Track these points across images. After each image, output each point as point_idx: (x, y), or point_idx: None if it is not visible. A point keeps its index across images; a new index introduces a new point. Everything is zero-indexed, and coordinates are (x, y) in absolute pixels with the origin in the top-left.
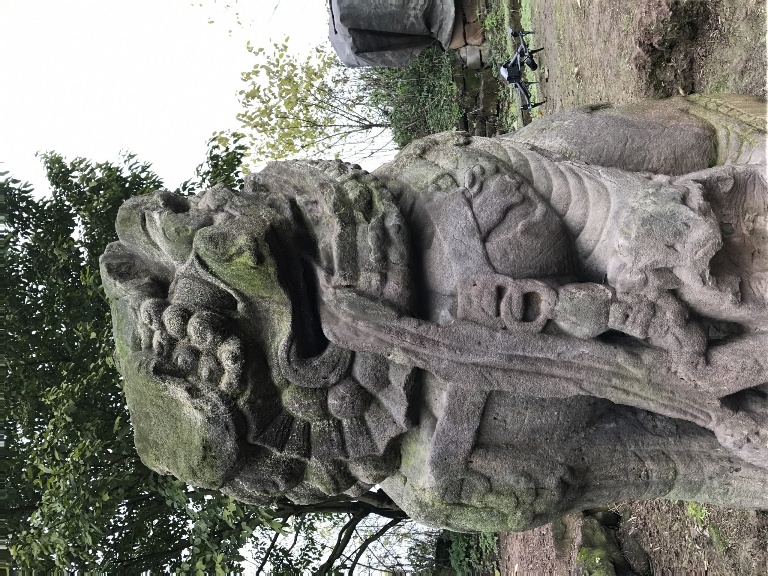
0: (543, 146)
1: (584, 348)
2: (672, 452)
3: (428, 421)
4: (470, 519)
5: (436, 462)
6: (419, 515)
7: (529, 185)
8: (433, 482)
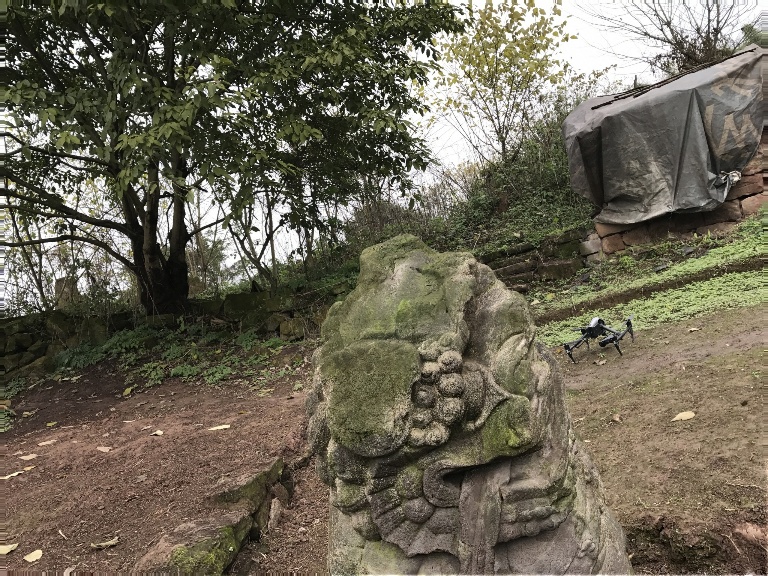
0: None
1: None
2: None
3: (416, 566)
4: None
5: None
6: (342, 567)
7: None
8: None
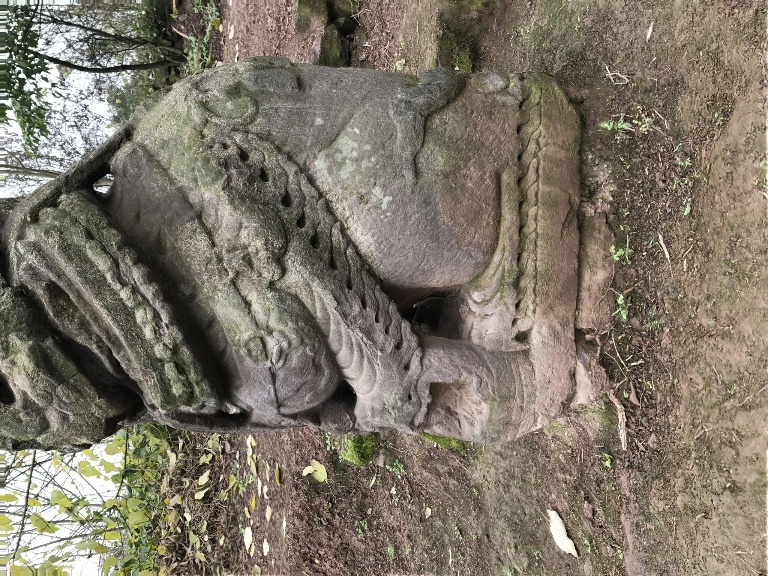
0: (354, 235)
1: None
2: None
3: None
4: None
5: None
6: None
7: (324, 346)
8: None
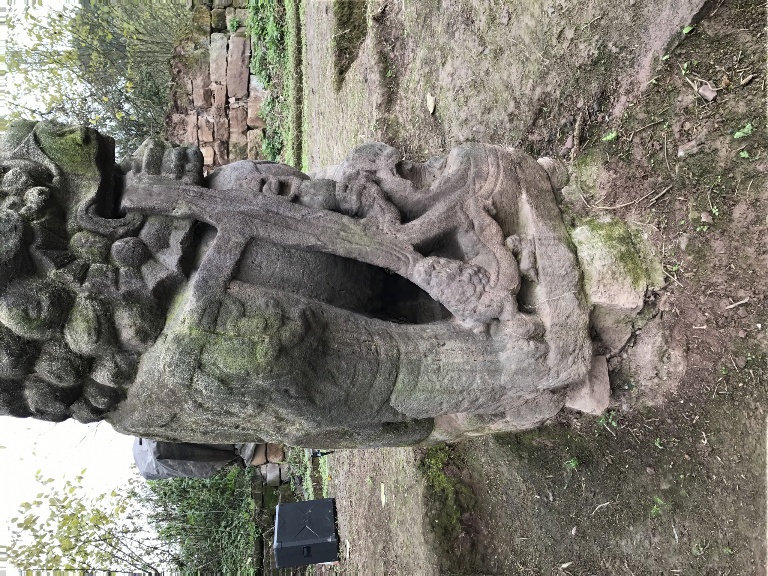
0: None
1: (320, 213)
2: (394, 333)
3: None
4: (223, 349)
5: (199, 285)
6: (174, 354)
7: None
8: (194, 305)
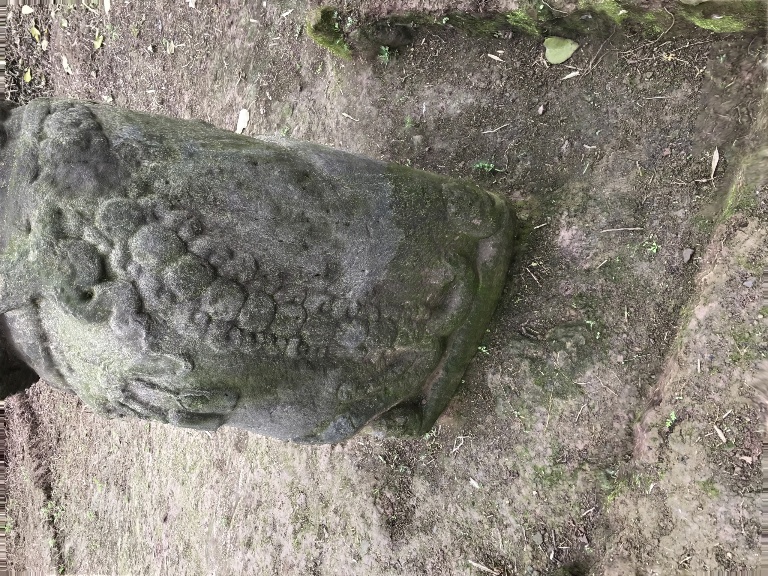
0: None
1: None
2: None
3: None
4: None
5: None
6: None
7: None
8: None
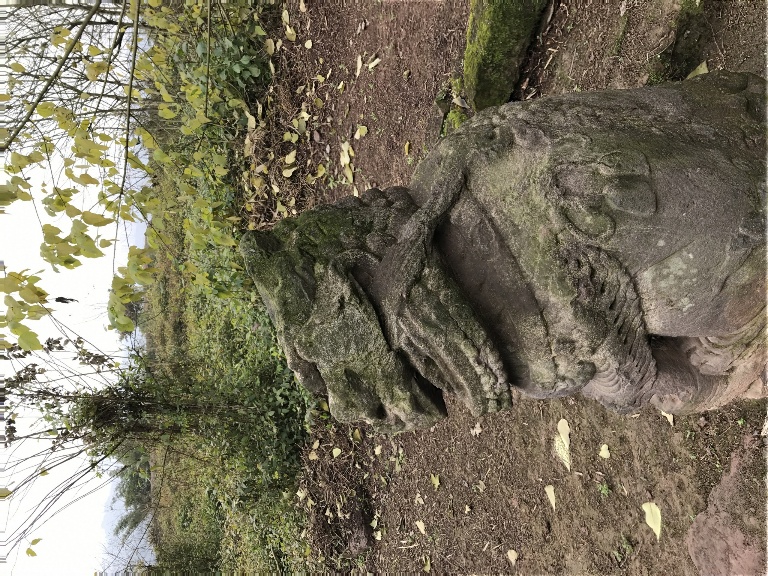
0: (649, 319)
1: None
2: None
3: None
4: None
5: None
6: None
7: None
8: None
